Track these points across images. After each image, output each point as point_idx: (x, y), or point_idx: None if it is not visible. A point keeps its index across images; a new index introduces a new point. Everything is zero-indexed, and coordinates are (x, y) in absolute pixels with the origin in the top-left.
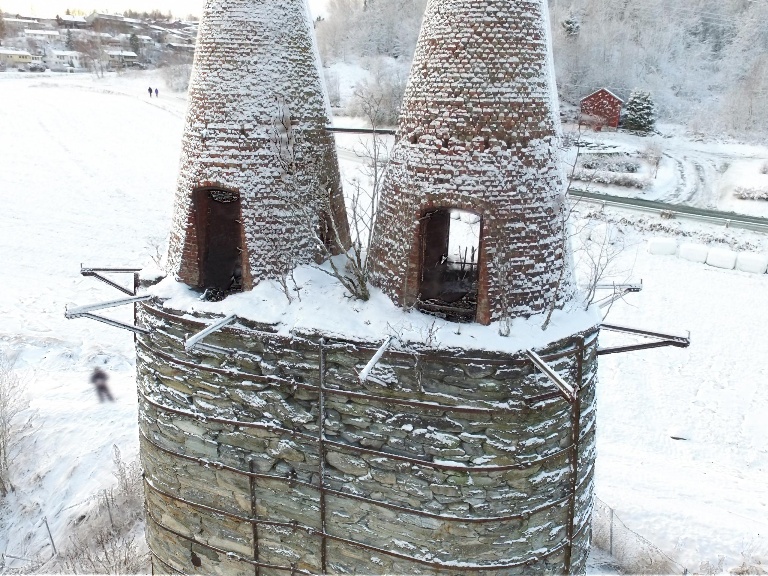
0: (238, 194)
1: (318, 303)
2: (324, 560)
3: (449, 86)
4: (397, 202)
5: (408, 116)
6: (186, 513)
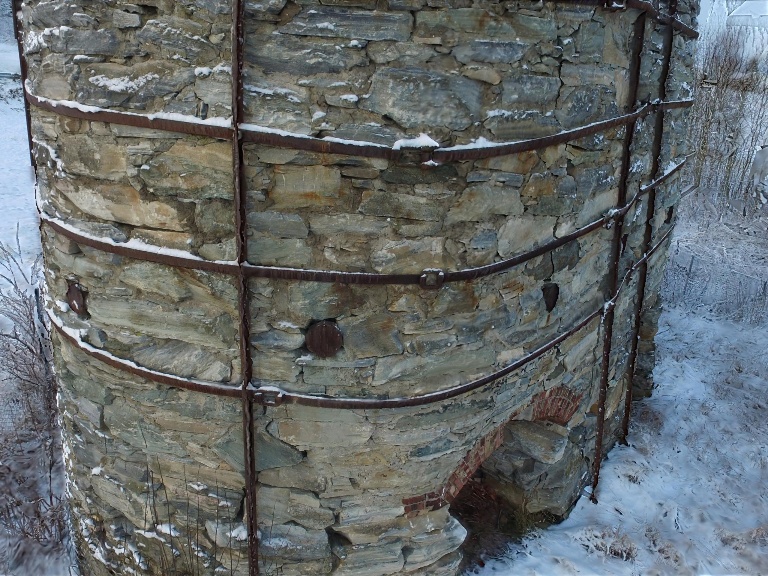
0: None
1: None
2: (655, 153)
3: None
4: None
5: None
6: (561, 172)
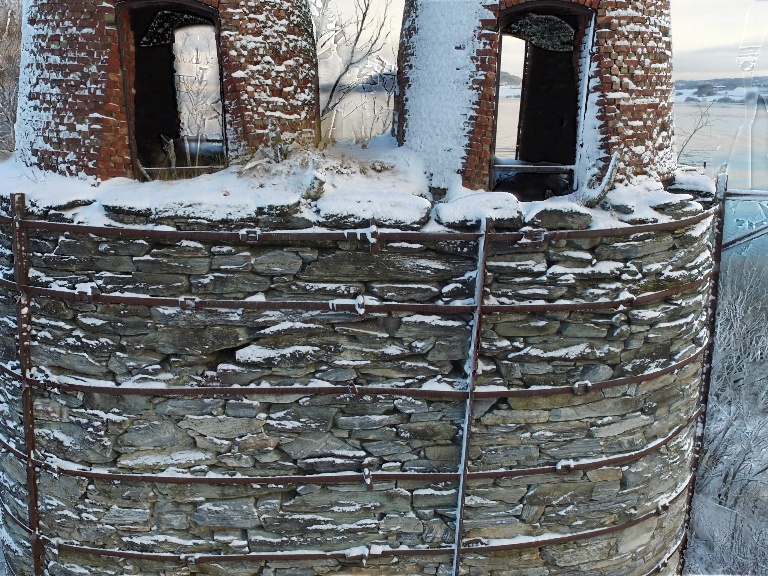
0: None
1: None
2: None
3: None
4: None
5: None
6: None
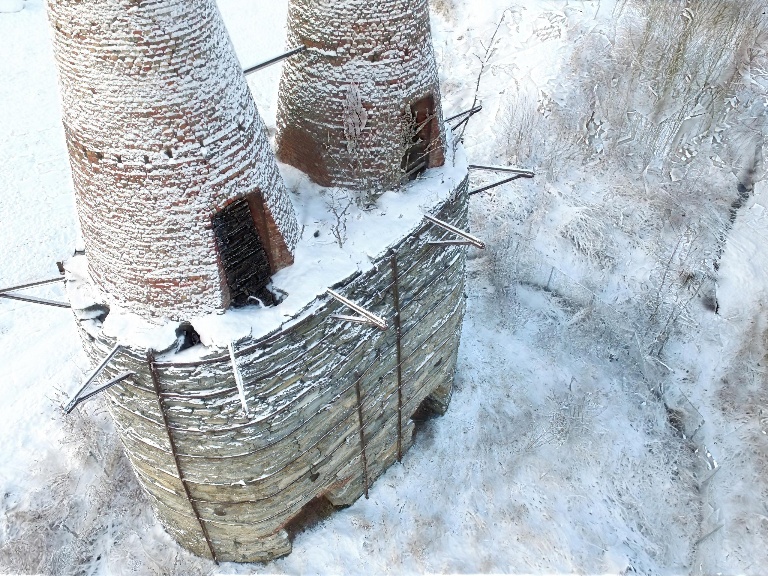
0: (259, 192)
1: (358, 230)
2: None
3: (400, 3)
4: (374, 116)
5: (358, 38)
6: None
